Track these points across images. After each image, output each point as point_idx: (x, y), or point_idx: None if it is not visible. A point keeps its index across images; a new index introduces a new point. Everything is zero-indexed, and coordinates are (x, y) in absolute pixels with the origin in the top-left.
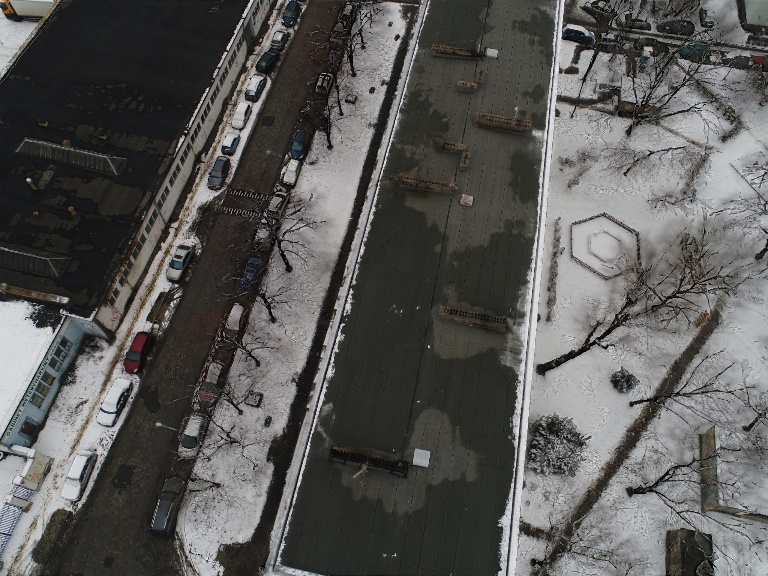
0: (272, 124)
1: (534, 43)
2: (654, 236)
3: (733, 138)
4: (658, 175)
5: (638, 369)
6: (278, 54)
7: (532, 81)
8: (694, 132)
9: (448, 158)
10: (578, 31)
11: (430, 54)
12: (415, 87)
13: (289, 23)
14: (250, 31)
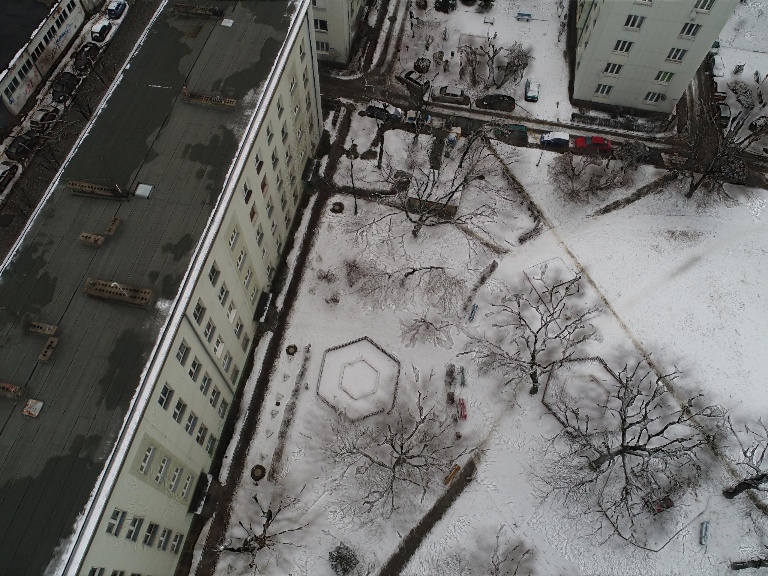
0: (9, 224)
1: (203, 175)
2: (419, 365)
3: (533, 239)
4: (413, 301)
5: (366, 541)
6: (36, 137)
7: (182, 229)
8: (490, 232)
9: (34, 344)
10: (381, 109)
11: (69, 192)
12: (34, 239)
13: (58, 98)
14: (7, 110)
